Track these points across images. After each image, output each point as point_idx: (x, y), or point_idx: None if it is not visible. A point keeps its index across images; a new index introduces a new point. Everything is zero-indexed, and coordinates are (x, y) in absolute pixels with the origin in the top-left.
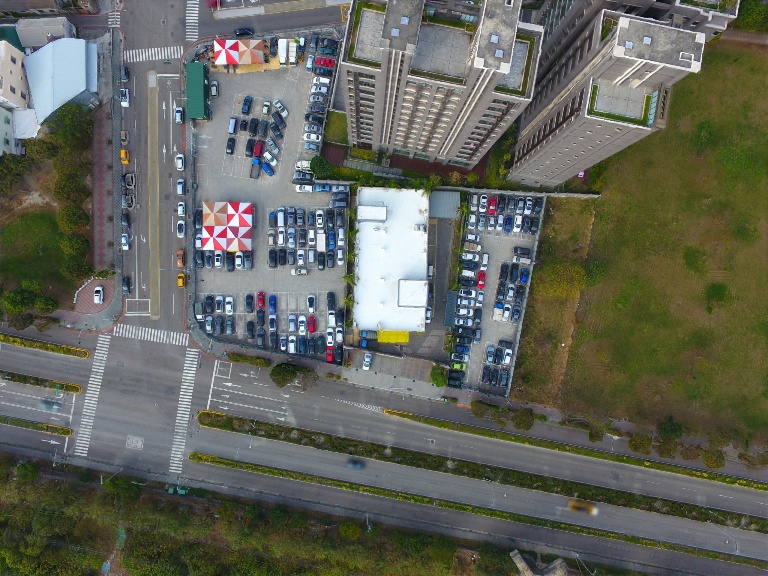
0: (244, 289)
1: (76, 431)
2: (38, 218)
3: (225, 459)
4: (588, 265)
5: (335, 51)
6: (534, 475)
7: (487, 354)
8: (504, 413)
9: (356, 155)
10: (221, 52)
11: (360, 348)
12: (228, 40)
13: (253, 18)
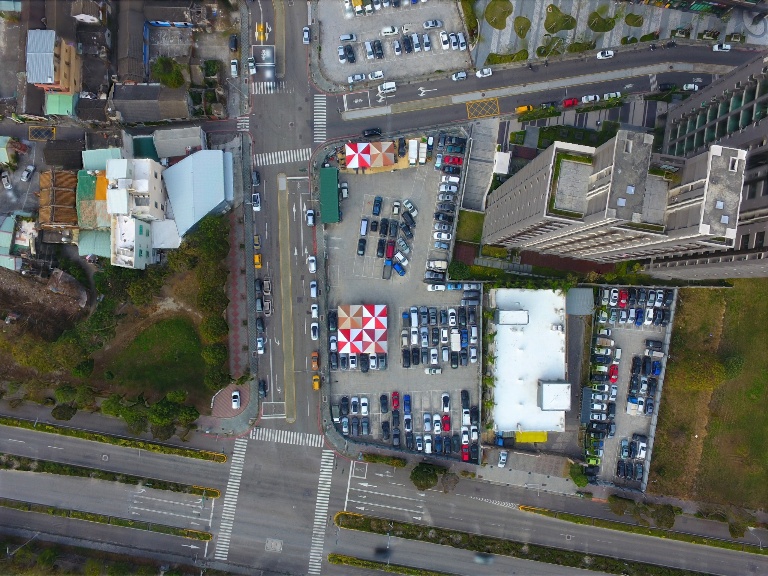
0: (378, 389)
1: (216, 535)
2: (173, 324)
3: (364, 560)
4: (727, 361)
5: (463, 149)
6: (672, 569)
7: (622, 449)
8: (644, 510)
9: (487, 253)
10: (354, 156)
11: (497, 447)
12: (359, 143)
13: (380, 118)
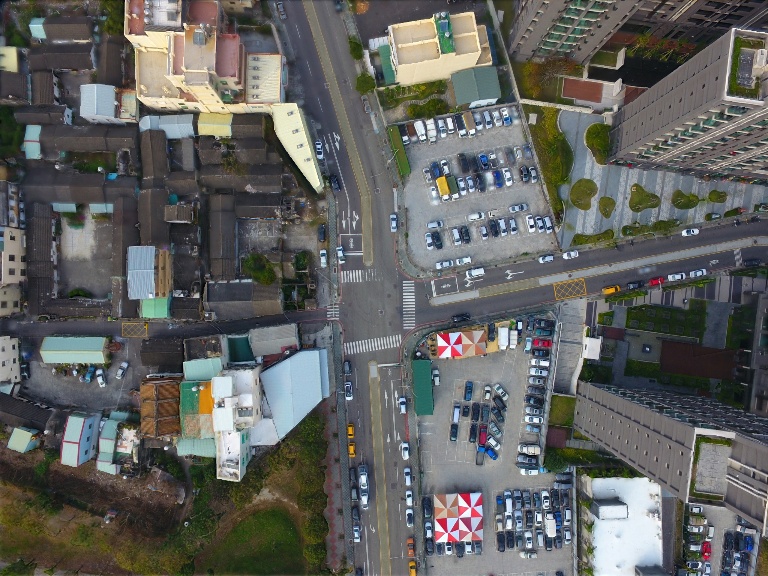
0: (473, 573)
1: None
2: (270, 515)
3: None
4: None
5: (552, 332)
6: None
7: None
8: None
9: (579, 436)
10: (447, 348)
11: None
12: (451, 333)
13: (468, 302)
